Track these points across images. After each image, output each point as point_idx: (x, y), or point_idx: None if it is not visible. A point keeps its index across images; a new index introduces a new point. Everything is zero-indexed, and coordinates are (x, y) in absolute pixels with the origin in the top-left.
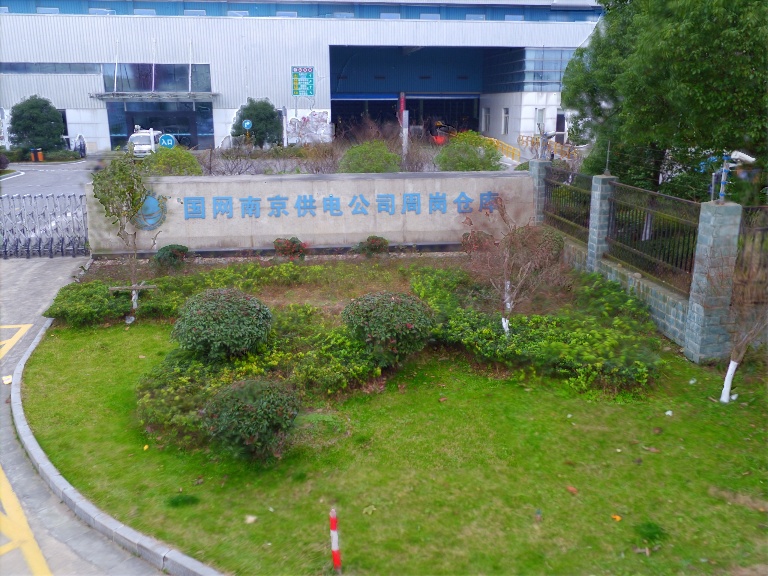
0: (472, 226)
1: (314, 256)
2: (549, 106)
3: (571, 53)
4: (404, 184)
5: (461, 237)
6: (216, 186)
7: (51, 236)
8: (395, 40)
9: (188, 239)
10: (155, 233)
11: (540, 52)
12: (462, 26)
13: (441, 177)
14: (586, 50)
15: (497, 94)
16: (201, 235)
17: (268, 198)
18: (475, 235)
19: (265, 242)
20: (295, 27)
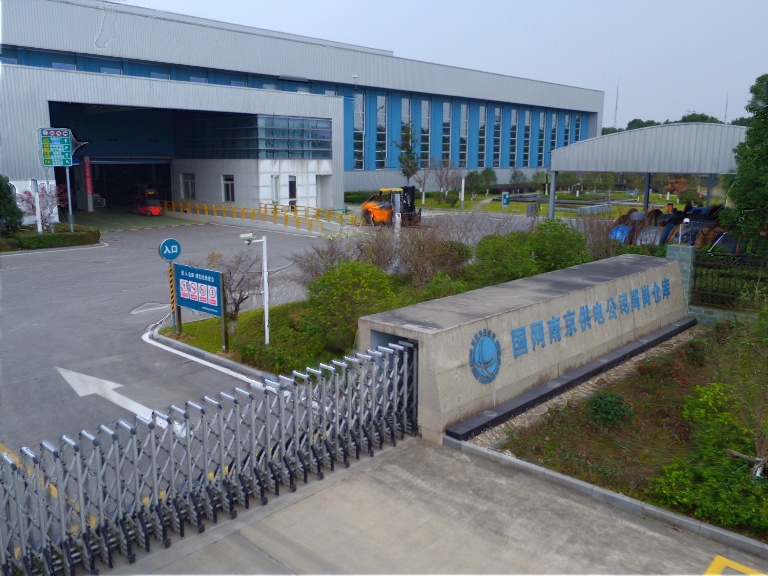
0: (662, 314)
1: (607, 373)
2: (283, 173)
3: (294, 122)
4: (629, 281)
5: (658, 326)
6: (531, 310)
7: (362, 422)
8: (127, 99)
9: (518, 383)
10: (495, 384)
11: (269, 120)
12: (197, 89)
13: (634, 269)
14: (759, 152)
15: (209, 160)
16: (527, 375)
17: (564, 315)
18: (736, 323)
19: (565, 368)
20: (0, 75)
